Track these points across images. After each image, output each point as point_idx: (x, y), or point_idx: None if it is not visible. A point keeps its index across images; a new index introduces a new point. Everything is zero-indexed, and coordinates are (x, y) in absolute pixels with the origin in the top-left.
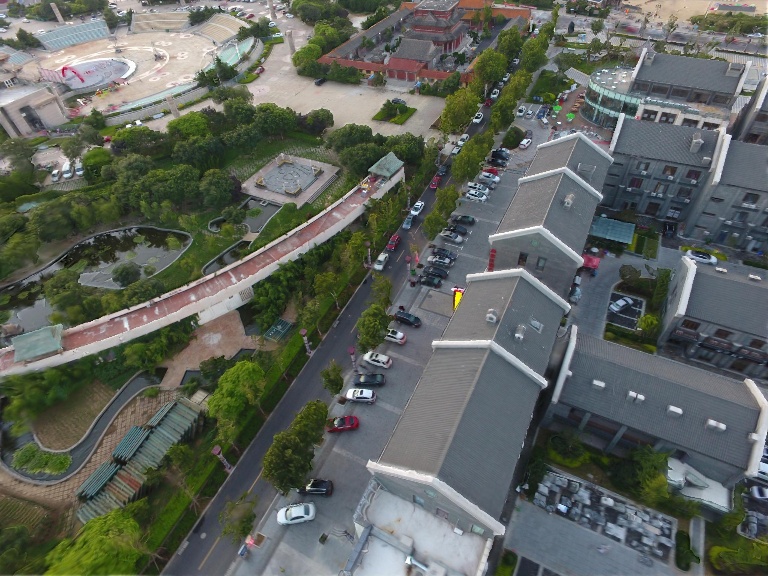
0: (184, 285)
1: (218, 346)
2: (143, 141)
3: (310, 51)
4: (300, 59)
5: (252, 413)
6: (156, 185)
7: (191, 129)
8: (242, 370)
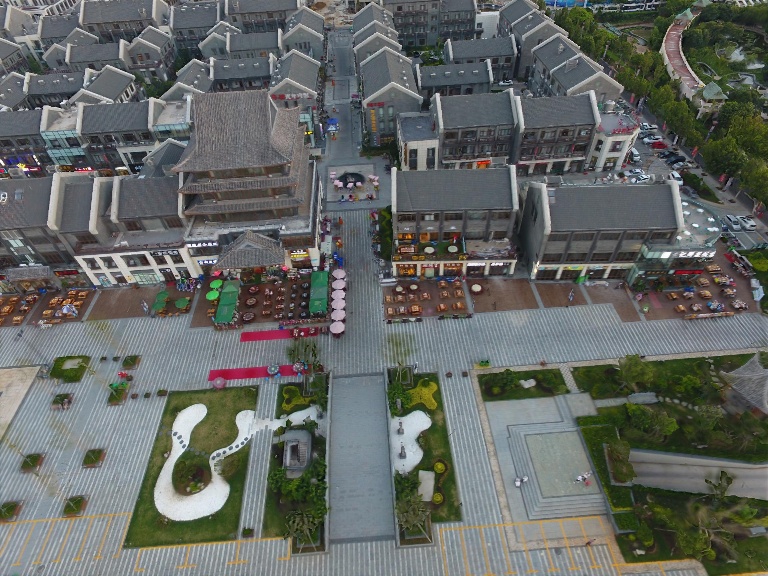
0: None
1: None
2: None
3: None
4: None
5: None
6: None
7: None
8: (610, 34)
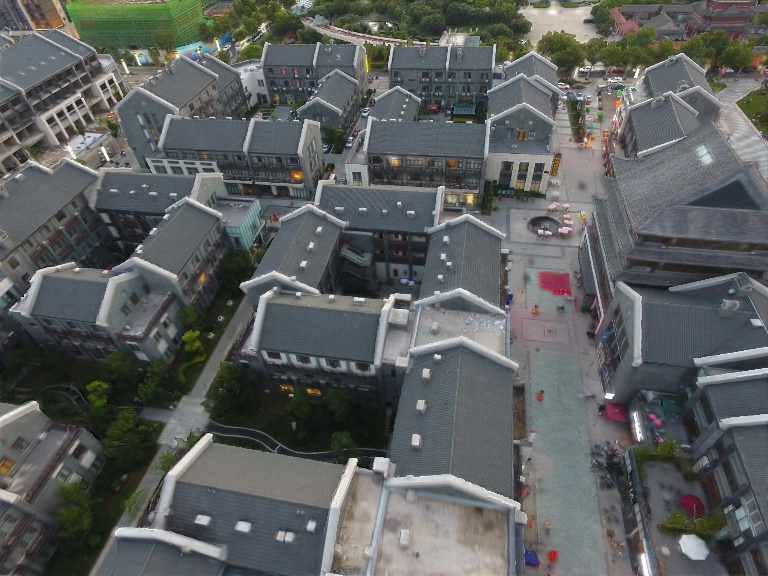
0: (359, 33)
1: None
2: (458, 0)
3: (617, 1)
4: (603, 3)
5: None
6: (418, 10)
7: (478, 4)
8: None
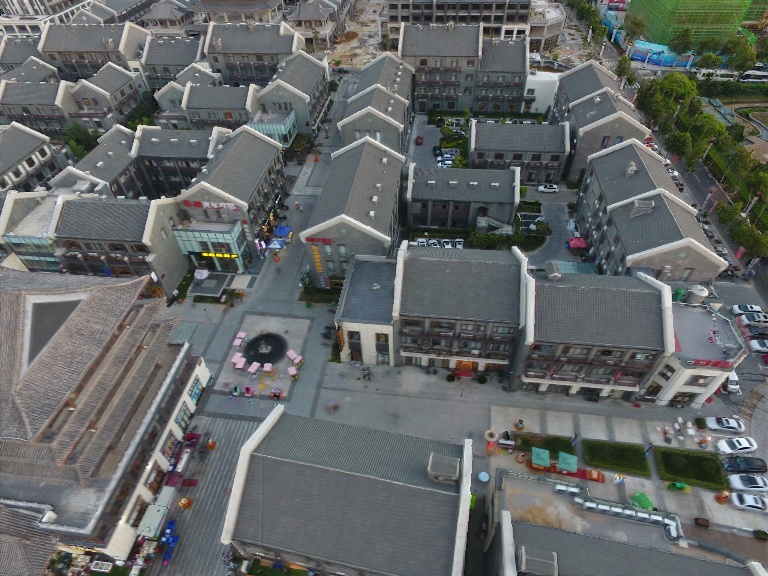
0: None
1: (759, 154)
2: None
3: None
4: None
5: (690, 129)
6: None
7: None
8: (717, 124)
